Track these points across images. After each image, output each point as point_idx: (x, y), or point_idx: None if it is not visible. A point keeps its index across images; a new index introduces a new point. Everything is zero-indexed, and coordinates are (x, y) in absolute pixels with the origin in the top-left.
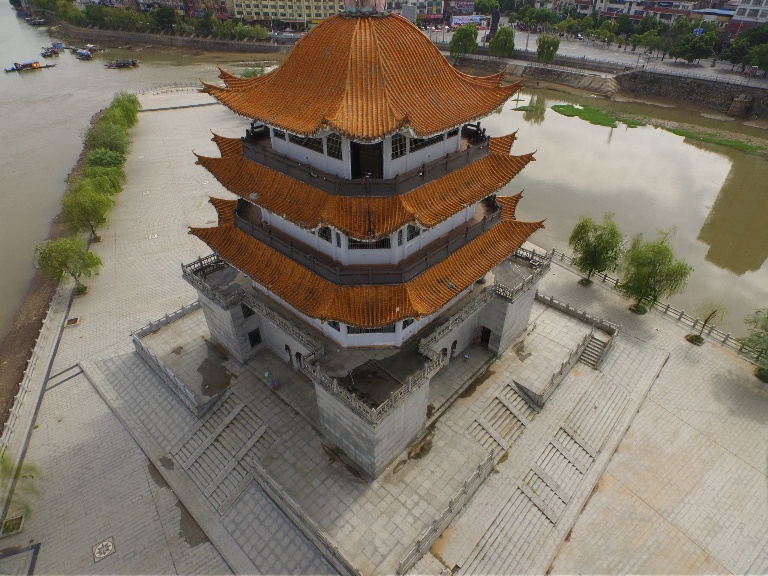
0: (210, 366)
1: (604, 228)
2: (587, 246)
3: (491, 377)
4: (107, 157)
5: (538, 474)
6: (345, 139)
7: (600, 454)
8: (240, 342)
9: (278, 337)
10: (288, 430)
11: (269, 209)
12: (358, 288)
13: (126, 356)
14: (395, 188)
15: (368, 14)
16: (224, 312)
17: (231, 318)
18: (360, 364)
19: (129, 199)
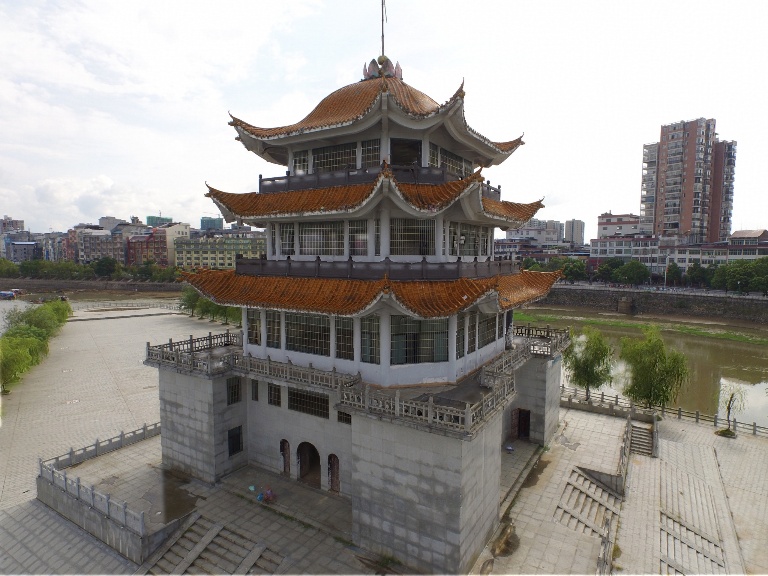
0: (162, 491)
1: (587, 342)
2: (577, 361)
3: (549, 466)
4: (30, 332)
5: (673, 566)
6: (385, 142)
7: (724, 543)
8: (216, 442)
9: (270, 432)
10: (298, 547)
11: (300, 210)
12: (410, 285)
13: (17, 508)
14: (443, 177)
15: (390, 76)
16: (201, 395)
17: (212, 399)
18: (414, 397)
19: (44, 376)
